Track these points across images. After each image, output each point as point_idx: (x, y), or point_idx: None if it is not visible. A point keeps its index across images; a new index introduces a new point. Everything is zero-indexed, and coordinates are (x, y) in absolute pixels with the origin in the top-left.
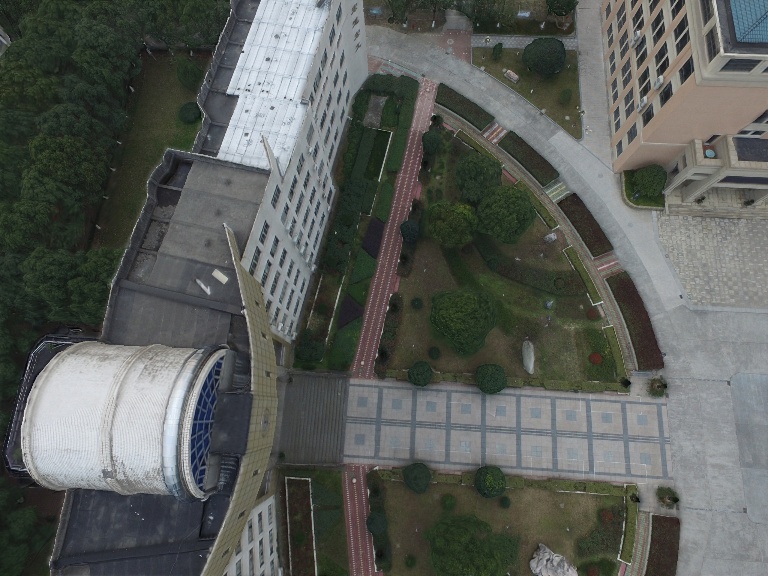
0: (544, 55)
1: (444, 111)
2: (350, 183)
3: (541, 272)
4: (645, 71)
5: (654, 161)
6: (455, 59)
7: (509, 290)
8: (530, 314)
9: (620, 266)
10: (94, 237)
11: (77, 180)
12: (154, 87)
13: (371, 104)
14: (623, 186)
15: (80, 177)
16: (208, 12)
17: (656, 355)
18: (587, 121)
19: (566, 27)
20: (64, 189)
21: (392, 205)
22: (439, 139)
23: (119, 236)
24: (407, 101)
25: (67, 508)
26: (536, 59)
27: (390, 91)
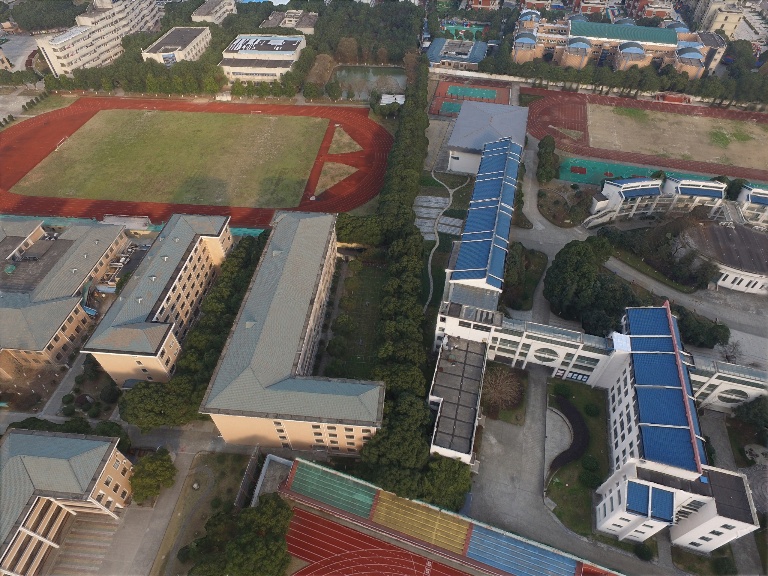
0: None
1: None
2: None
3: None
4: None
5: None
6: None
7: None
8: None
9: None
10: None
11: None
12: None
13: None
14: None
15: None
16: None
17: (35, 50)
18: None
19: None
20: None
21: None
22: None
23: None
24: None
25: (124, 2)
26: None
27: None
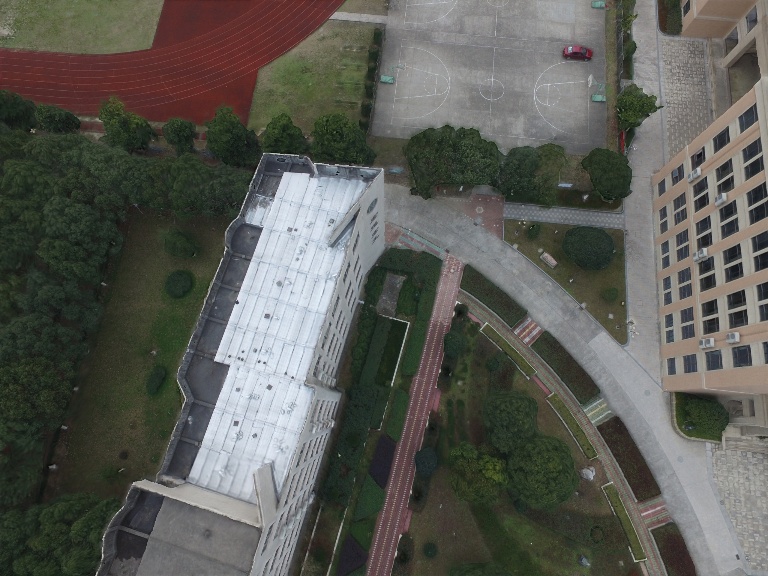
0: (590, 254)
1: (470, 298)
2: (358, 391)
3: (576, 518)
4: (712, 302)
5: (714, 395)
6: (484, 232)
7: (538, 538)
8: (561, 570)
9: (667, 512)
10: (59, 439)
11: (34, 413)
12: (139, 247)
13: (386, 284)
14: (673, 410)
15: (38, 409)
16: (202, 187)
17: None
18: None
19: (612, 200)
20: (17, 429)
21: (406, 417)
22: (464, 343)
23: (88, 438)
24: (428, 286)
25: None
26: (580, 256)
27: (409, 271)
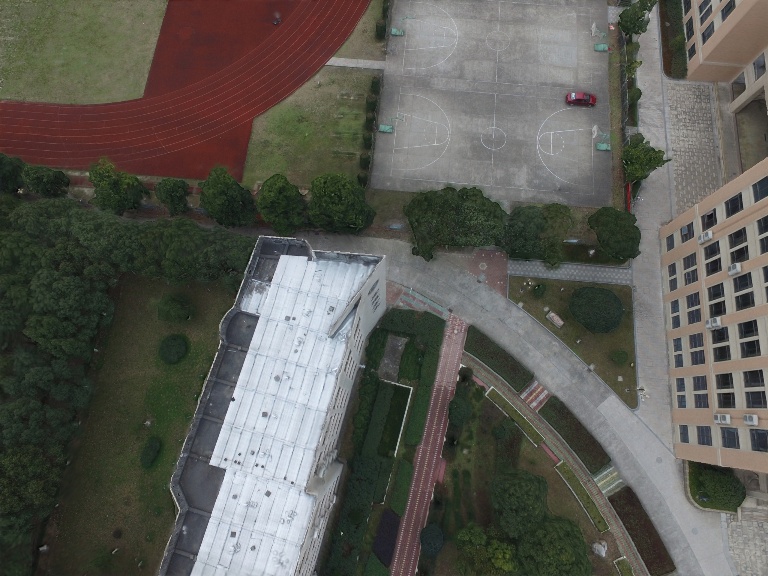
0: (598, 319)
1: (474, 360)
2: (361, 463)
3: None
4: (727, 375)
5: (729, 467)
6: (488, 290)
7: None
8: None
9: None
10: (50, 517)
11: (22, 505)
12: (131, 310)
13: (388, 347)
14: (687, 479)
15: (26, 501)
16: (196, 255)
17: None
18: (643, 383)
19: None
20: (4, 524)
21: (410, 489)
22: (469, 412)
23: (80, 516)
24: (431, 349)
25: None
26: (588, 320)
27: (411, 333)
